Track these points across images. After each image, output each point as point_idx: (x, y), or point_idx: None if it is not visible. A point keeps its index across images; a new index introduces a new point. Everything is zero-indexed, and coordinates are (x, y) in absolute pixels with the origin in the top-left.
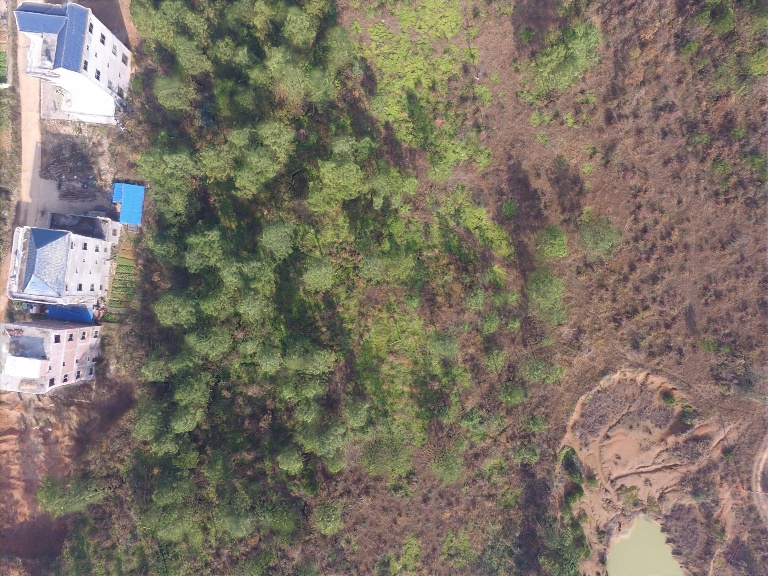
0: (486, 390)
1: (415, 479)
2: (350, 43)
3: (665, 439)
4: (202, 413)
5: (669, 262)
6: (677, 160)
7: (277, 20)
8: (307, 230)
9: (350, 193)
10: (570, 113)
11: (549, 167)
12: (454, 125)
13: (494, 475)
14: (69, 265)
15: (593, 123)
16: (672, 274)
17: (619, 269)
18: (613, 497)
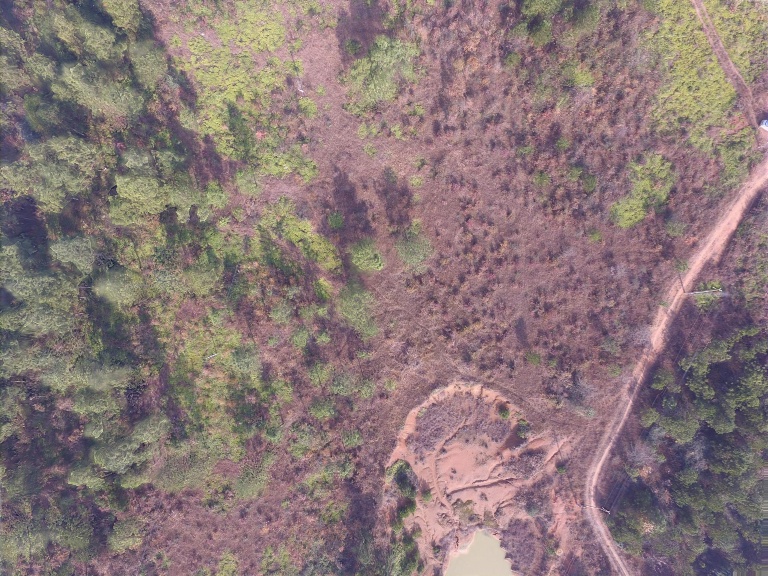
0: (309, 404)
1: (231, 494)
2: (170, 56)
3: (501, 453)
4: (14, 428)
5: (499, 274)
6: (505, 172)
7: (81, 35)
8: (127, 243)
9: (155, 207)
10: (398, 125)
11: (377, 179)
12: (277, 138)
13: (317, 490)
14: None
15: (421, 135)
16: (502, 286)
17: (449, 281)
18: (449, 511)
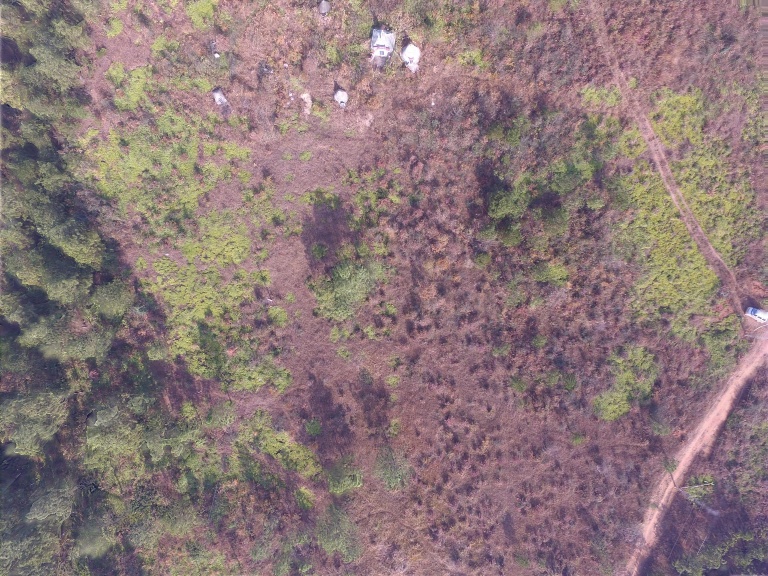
0: None
1: None
2: (136, 278)
3: None
4: None
5: (483, 471)
6: (483, 368)
7: None
8: (107, 468)
9: (128, 448)
10: (370, 326)
11: (352, 382)
12: (249, 350)
13: None
14: None
15: (394, 334)
16: (486, 483)
17: (432, 480)
18: None
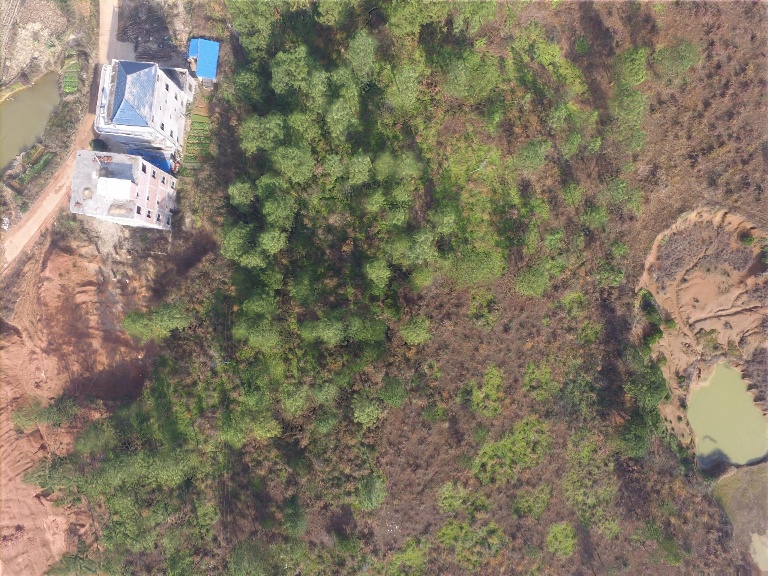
0: (564, 223)
1: (496, 307)
2: None
3: (744, 281)
4: (284, 241)
5: (744, 98)
6: None
7: None
8: (383, 67)
9: (431, 15)
10: None
11: (620, 6)
12: None
13: (574, 308)
14: (155, 96)
15: None
16: (748, 110)
17: (693, 106)
18: (692, 342)
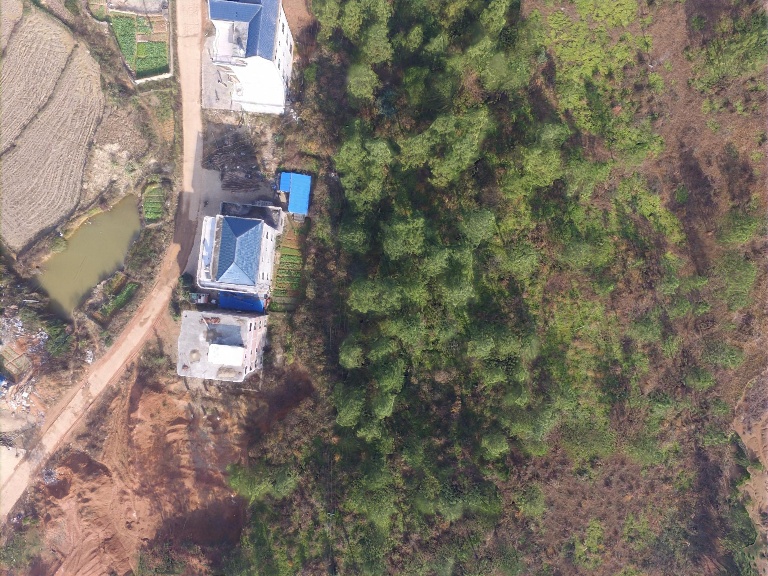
0: (662, 375)
1: (599, 463)
2: (529, 31)
3: None
4: None
5: None
6: None
7: (473, 8)
8: None
9: (545, 180)
10: (739, 100)
11: (719, 154)
12: (629, 113)
13: (670, 458)
14: None
15: (762, 110)
16: None
17: None
18: None
